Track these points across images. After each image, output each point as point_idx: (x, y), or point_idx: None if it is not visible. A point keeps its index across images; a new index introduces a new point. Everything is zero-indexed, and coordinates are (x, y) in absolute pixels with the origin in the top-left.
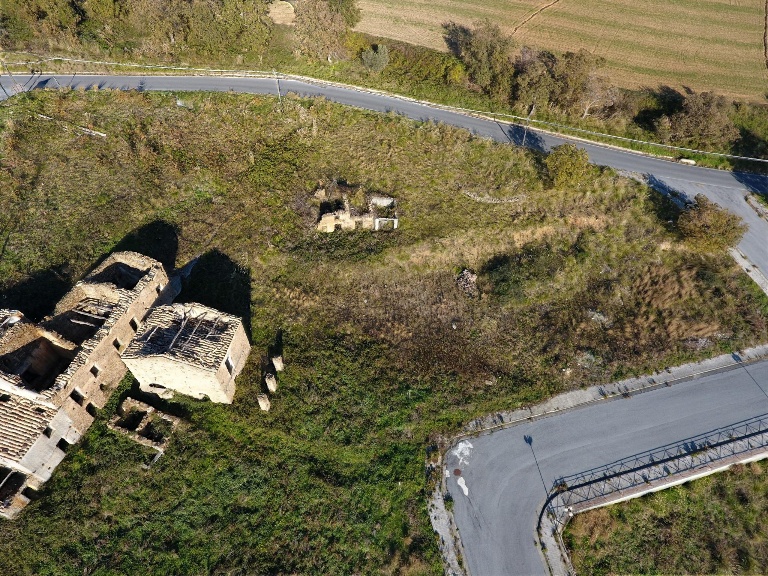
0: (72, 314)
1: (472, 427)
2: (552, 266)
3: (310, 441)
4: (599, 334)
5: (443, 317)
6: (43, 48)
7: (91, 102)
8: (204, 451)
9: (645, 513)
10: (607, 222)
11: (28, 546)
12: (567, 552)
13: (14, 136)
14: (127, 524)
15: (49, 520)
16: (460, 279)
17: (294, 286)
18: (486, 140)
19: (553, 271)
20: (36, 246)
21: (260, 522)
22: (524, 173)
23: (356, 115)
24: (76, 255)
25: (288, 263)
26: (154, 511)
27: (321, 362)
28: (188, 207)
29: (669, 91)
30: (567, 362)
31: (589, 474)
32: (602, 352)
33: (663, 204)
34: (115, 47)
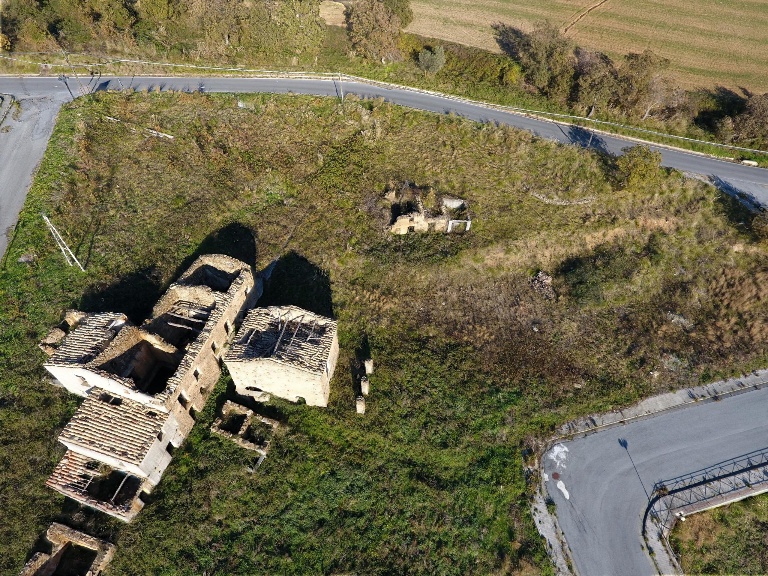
0: (167, 317)
1: (565, 430)
2: (627, 268)
3: (407, 444)
4: (681, 337)
5: (523, 319)
6: (101, 50)
7: (155, 104)
8: (305, 454)
9: (747, 517)
10: (677, 224)
11: (149, 550)
12: (676, 557)
13: (86, 138)
14: (238, 528)
15: (166, 524)
16: (535, 281)
17: (372, 288)
18: (551, 142)
19: (630, 273)
20: (121, 248)
21: (367, 526)
22: (591, 175)
23: (417, 116)
24: (161, 257)
25: (365, 265)
26: (262, 515)
27: (409, 365)
28: (261, 209)
29: (726, 92)
30: (654, 365)
31: (688, 478)
32: (687, 355)
33: (733, 206)
34: (173, 49)
